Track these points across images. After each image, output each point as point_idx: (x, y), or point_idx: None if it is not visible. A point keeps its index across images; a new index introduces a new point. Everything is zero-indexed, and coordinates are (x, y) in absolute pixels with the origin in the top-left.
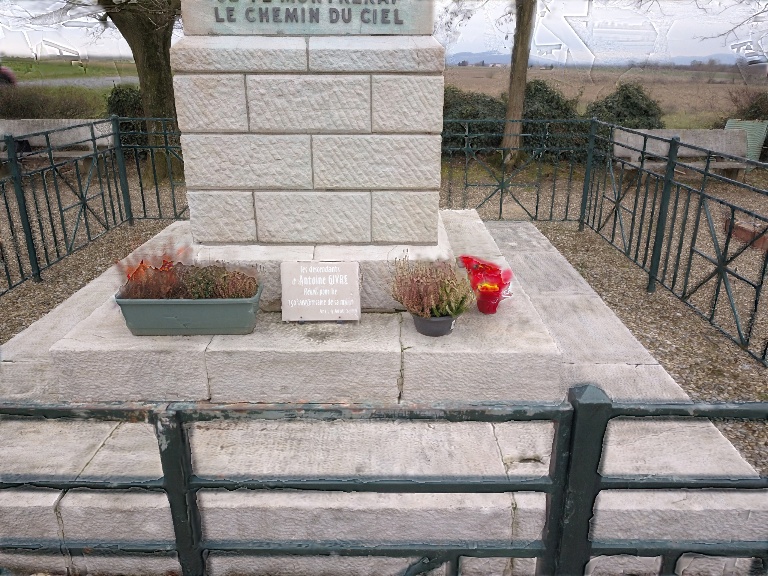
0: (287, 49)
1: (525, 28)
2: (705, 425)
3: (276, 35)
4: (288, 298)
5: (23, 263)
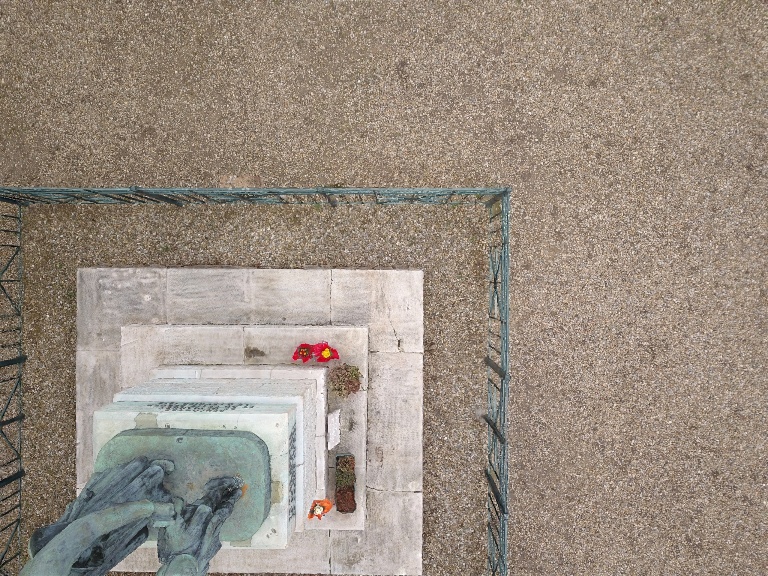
0: None
1: None
2: (379, 274)
3: None
4: None
5: None
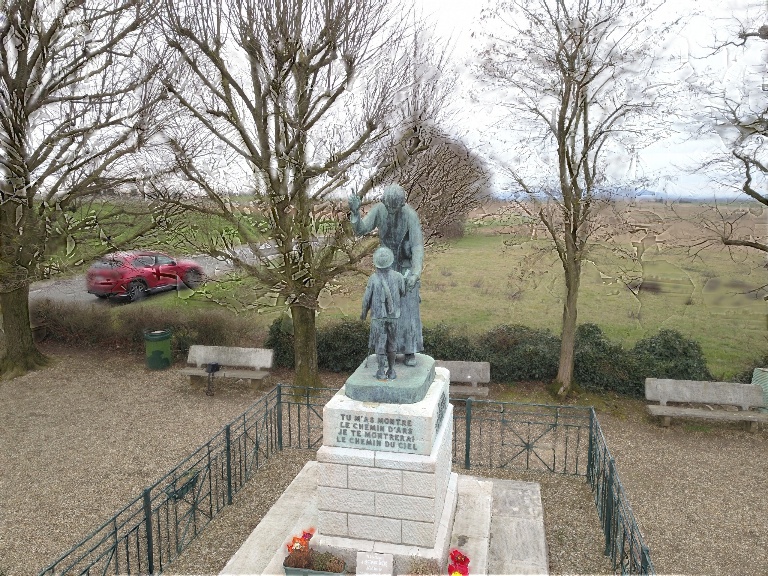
0: (366, 457)
1: (571, 298)
2: None
3: (362, 449)
4: (359, 570)
5: (219, 483)
